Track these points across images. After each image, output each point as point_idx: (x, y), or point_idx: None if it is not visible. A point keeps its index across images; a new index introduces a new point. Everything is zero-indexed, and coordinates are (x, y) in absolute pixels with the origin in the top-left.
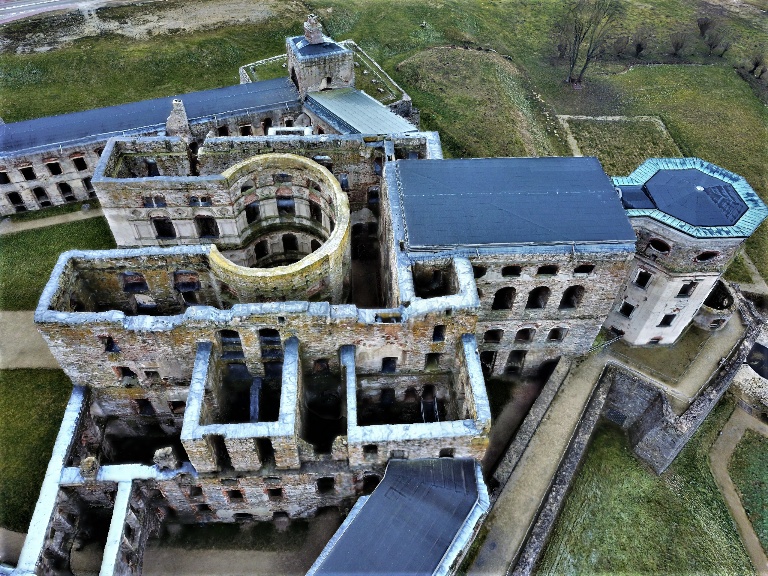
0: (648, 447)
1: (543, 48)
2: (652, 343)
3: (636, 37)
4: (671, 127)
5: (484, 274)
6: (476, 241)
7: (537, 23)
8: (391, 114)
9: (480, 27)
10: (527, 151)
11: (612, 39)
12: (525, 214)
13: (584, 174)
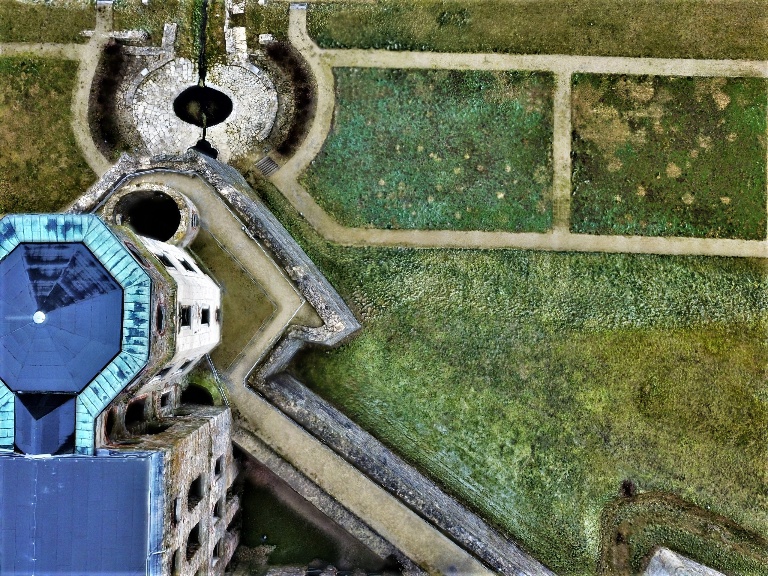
0: None
1: None
2: (218, 316)
3: None
4: None
5: None
6: None
7: None
8: None
9: None
10: None
11: None
12: None
13: None
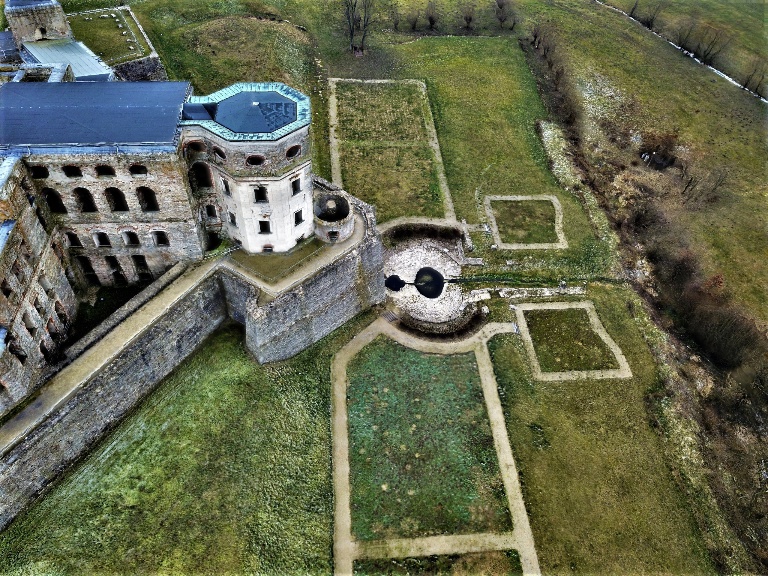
0: (249, 339)
1: (344, 21)
2: (268, 251)
3: (428, 10)
4: (431, 89)
5: (48, 174)
6: (27, 142)
7: None
8: (93, 60)
9: (288, 1)
10: None
11: None
12: (86, 122)
13: (165, 93)
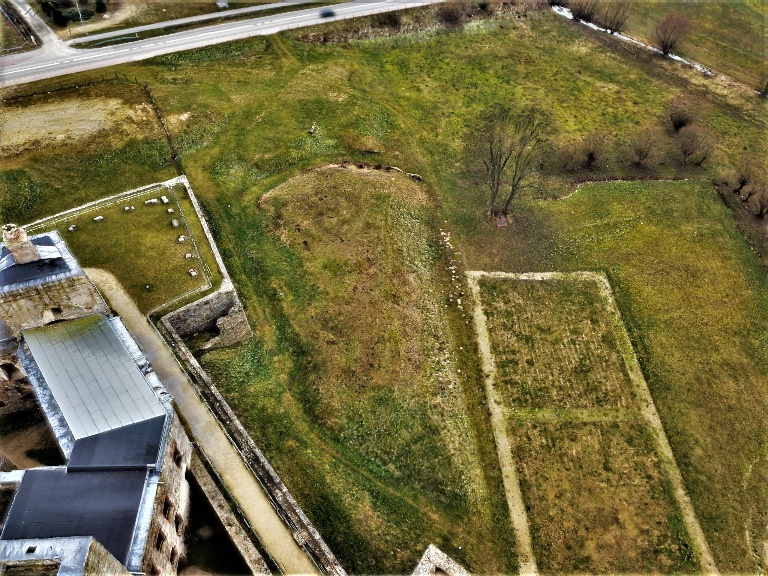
0: None
1: (469, 156)
2: None
3: (587, 144)
4: (619, 291)
5: None
6: None
7: (468, 116)
8: (136, 377)
9: (391, 126)
10: (402, 355)
11: (560, 140)
12: None
13: None
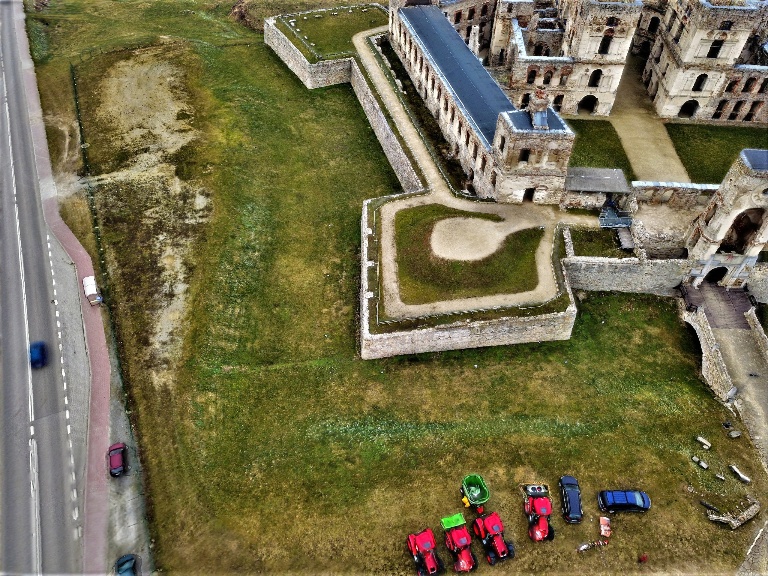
0: None
1: None
2: None
3: None
4: None
5: None
6: None
7: None
8: None
9: None
10: None
11: None
12: None
13: None
